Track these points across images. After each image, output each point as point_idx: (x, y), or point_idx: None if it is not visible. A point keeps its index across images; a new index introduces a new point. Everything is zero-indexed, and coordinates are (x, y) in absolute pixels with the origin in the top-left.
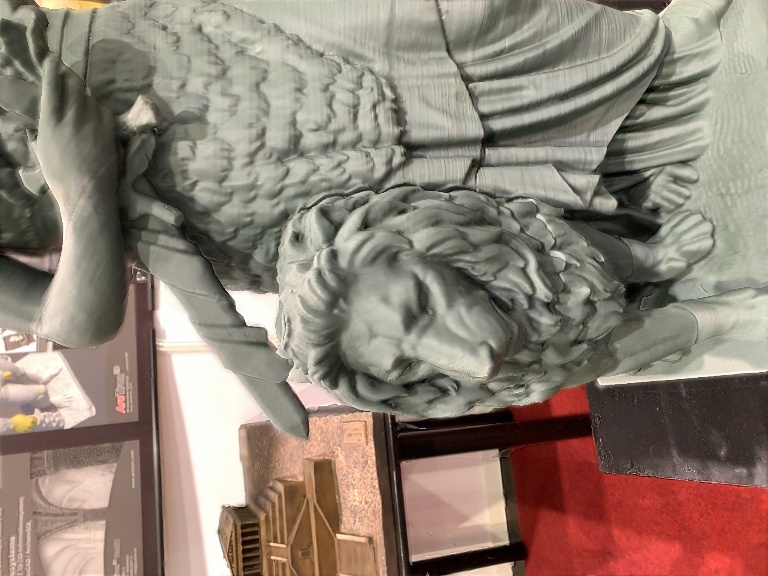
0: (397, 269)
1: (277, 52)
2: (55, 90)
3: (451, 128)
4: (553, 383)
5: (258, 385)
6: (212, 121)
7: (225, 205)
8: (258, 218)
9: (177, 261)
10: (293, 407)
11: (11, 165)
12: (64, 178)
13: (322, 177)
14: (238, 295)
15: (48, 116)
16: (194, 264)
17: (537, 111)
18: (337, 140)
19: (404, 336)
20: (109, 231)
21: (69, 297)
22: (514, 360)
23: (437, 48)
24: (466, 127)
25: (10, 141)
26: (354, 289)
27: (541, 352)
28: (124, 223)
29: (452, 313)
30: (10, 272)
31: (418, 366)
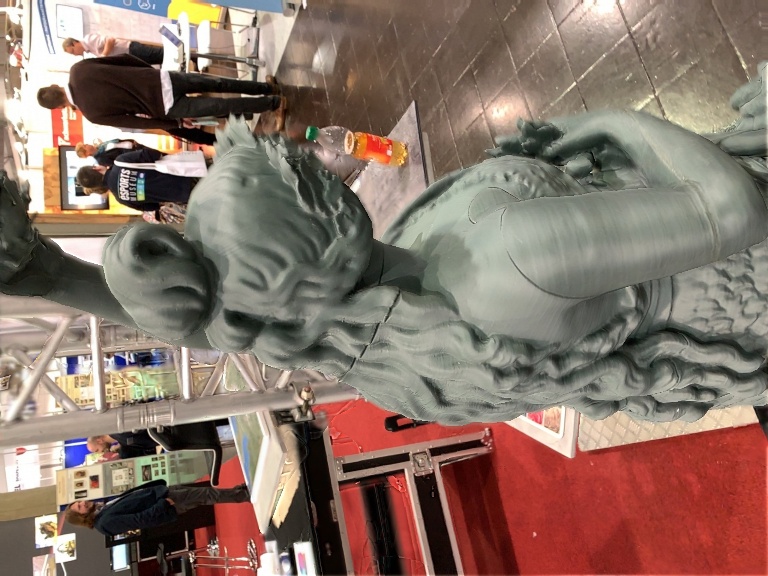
0: None
1: None
2: None
3: None
4: None
5: None
6: None
7: None
8: None
9: None
10: None
11: None
12: None
13: None
14: None
15: None
16: None
17: None
18: None
19: None
20: None
21: (681, 137)
22: None
23: None
24: None
25: None
26: None
27: None
28: None
29: None
30: None
31: None
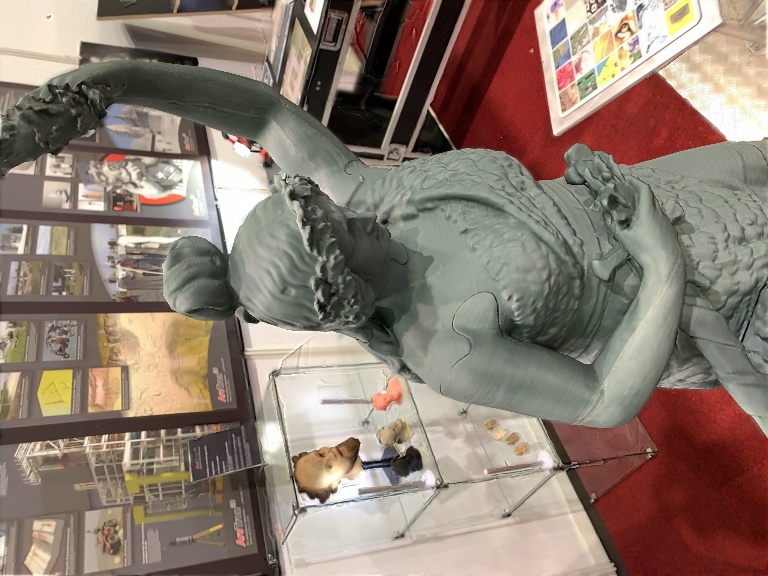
0: None
1: (697, 185)
2: (650, 188)
3: None
4: None
5: None
6: (693, 222)
7: (719, 278)
8: (742, 286)
9: (712, 318)
10: None
11: None
12: (664, 245)
13: None
14: (364, 569)
15: (650, 203)
16: (721, 320)
17: None
18: (763, 231)
19: None
20: (684, 288)
21: (649, 354)
22: None
23: None
24: None
25: (574, 246)
26: None
27: None
28: None
29: None
30: (567, 356)
31: None
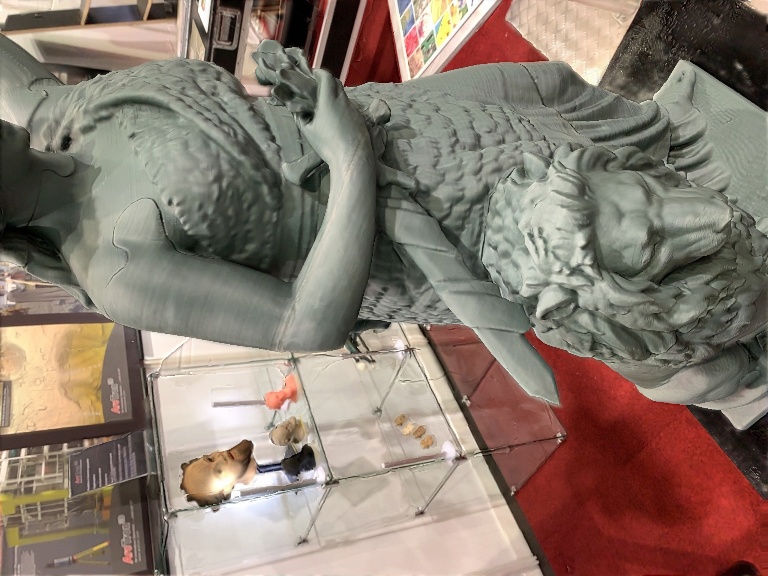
0: (613, 172)
1: (440, 97)
2: None
3: (572, 140)
4: (754, 293)
5: (505, 340)
6: (416, 128)
7: (441, 184)
8: (468, 192)
9: (419, 221)
10: (540, 362)
11: (269, 169)
12: (343, 136)
13: (509, 155)
14: None
15: (329, 92)
16: (432, 224)
17: (616, 140)
18: (505, 140)
19: (648, 206)
20: (373, 184)
21: (335, 259)
22: (722, 257)
23: (537, 102)
24: (581, 140)
25: (268, 151)
26: (591, 182)
27: (736, 252)
28: (376, 189)
29: (672, 192)
30: (259, 272)
31: (659, 251)
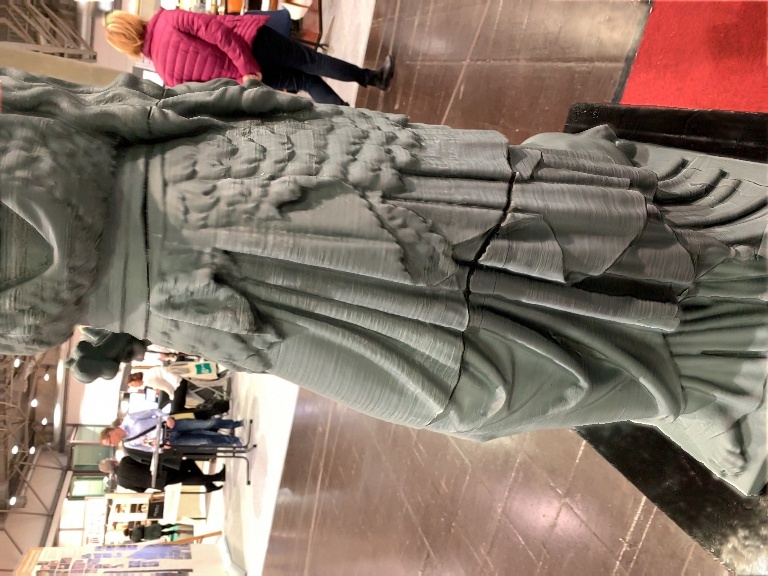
0: None
1: None
2: None
3: None
4: None
5: None
6: None
7: None
8: None
9: None
10: None
11: None
12: None
13: None
14: None
15: None
16: None
17: None
18: None
19: None
20: None
21: None
22: None
23: None
24: None
25: None
26: None
27: None
28: None
29: None
30: None
31: None
